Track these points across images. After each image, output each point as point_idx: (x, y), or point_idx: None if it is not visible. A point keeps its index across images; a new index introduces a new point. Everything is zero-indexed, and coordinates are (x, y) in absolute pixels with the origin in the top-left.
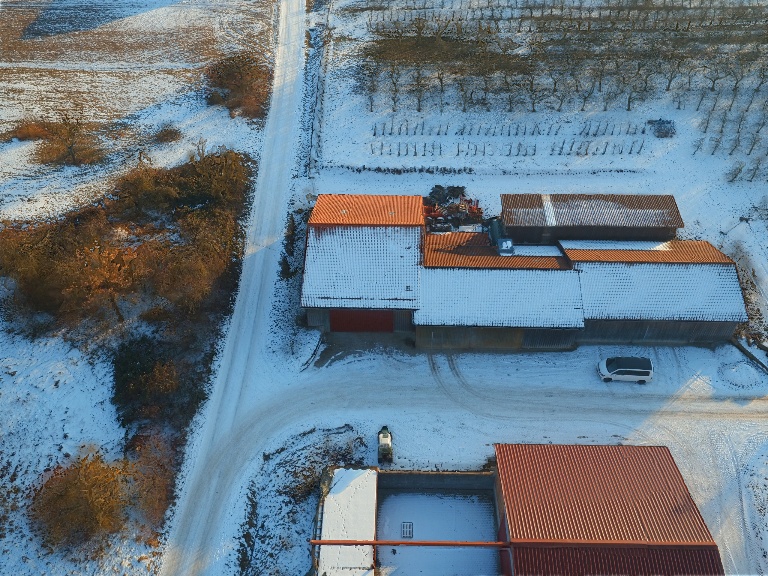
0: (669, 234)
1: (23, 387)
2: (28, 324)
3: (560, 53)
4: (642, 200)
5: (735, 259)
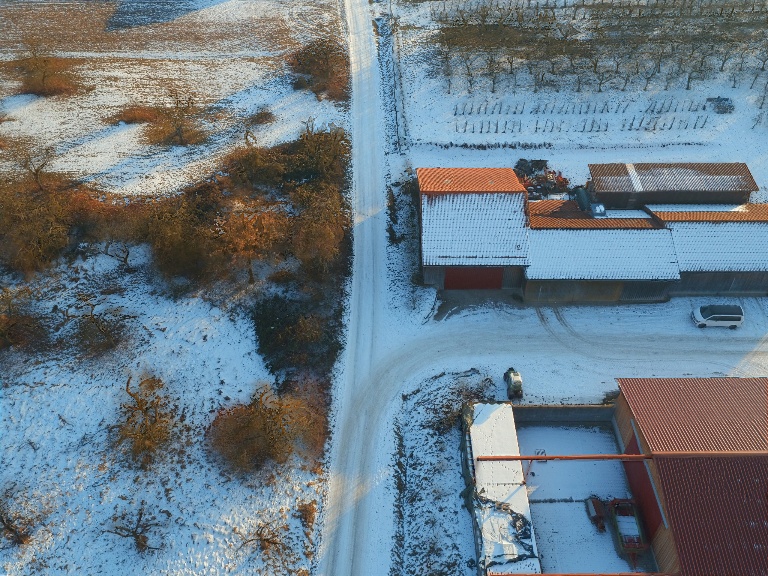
0: (743, 198)
1: (175, 341)
2: (168, 287)
3: (616, 38)
4: (718, 167)
5: None
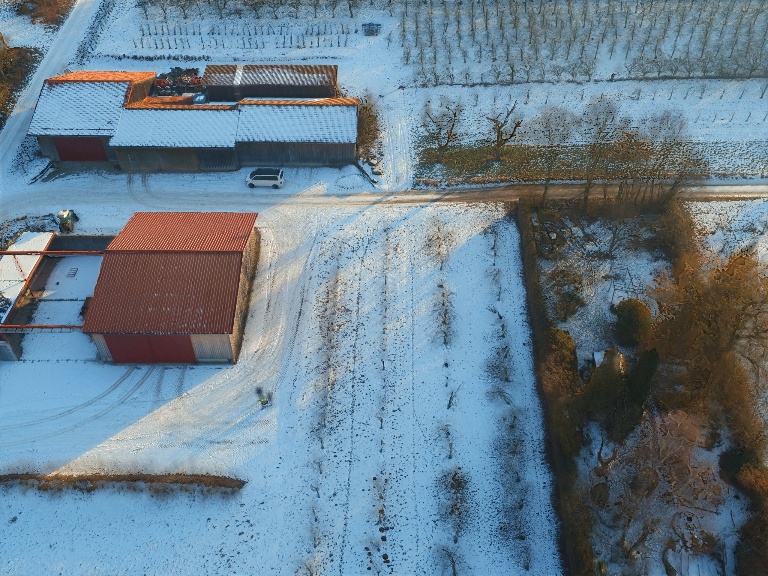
0: (330, 93)
1: None
2: None
3: None
4: (312, 68)
5: (381, 112)
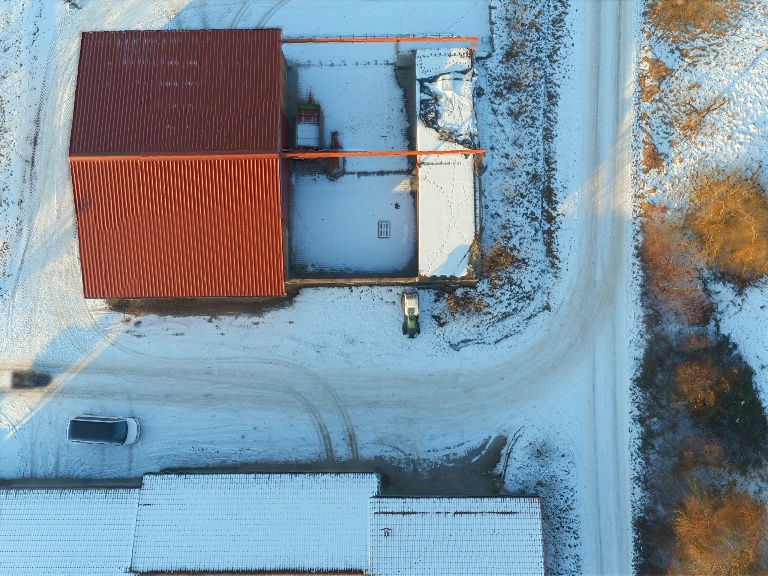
0: None
1: None
2: None
3: None
4: None
5: None
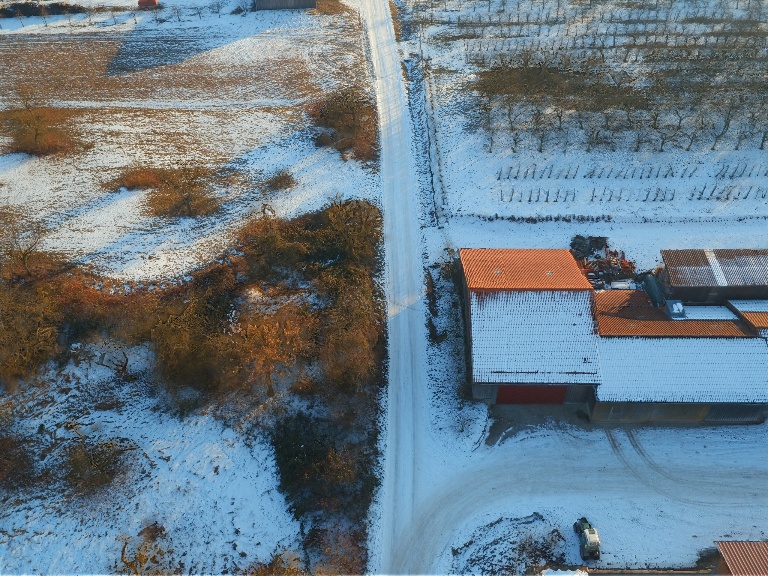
0: None
1: (181, 474)
2: (173, 400)
3: (674, 85)
4: None
5: None
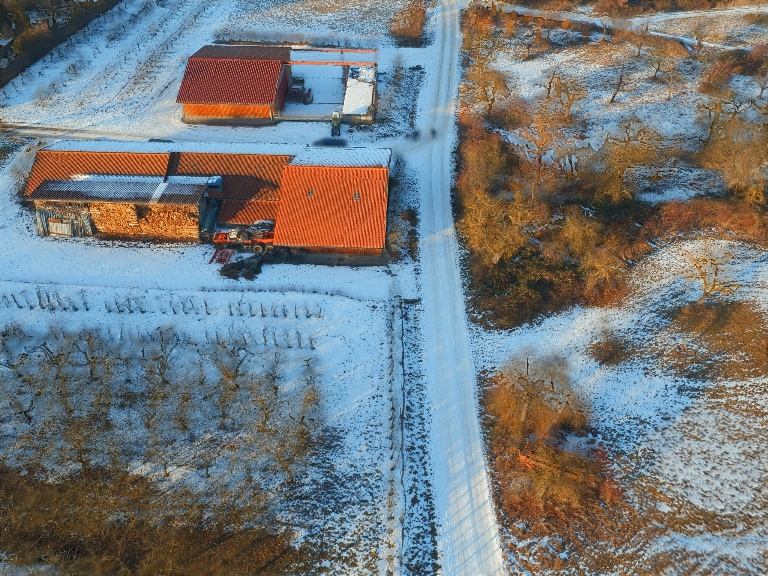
0: None
1: None
2: None
3: None
4: (61, 196)
5: (7, 199)
